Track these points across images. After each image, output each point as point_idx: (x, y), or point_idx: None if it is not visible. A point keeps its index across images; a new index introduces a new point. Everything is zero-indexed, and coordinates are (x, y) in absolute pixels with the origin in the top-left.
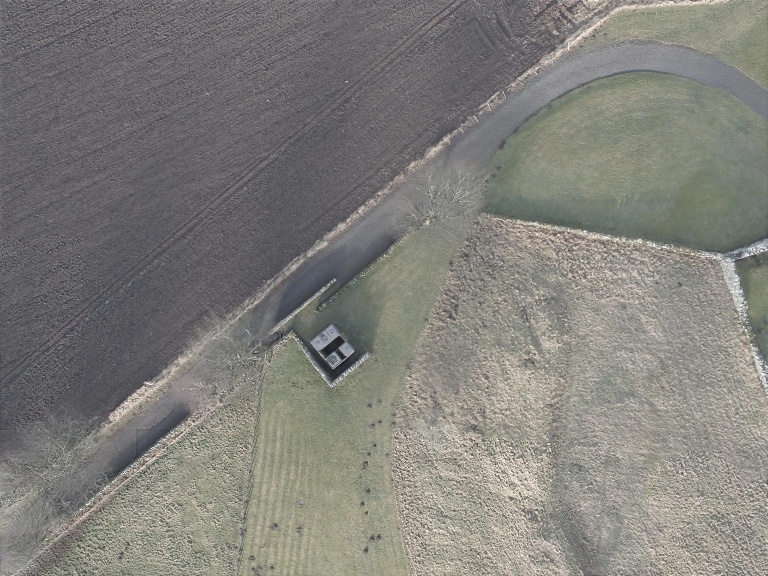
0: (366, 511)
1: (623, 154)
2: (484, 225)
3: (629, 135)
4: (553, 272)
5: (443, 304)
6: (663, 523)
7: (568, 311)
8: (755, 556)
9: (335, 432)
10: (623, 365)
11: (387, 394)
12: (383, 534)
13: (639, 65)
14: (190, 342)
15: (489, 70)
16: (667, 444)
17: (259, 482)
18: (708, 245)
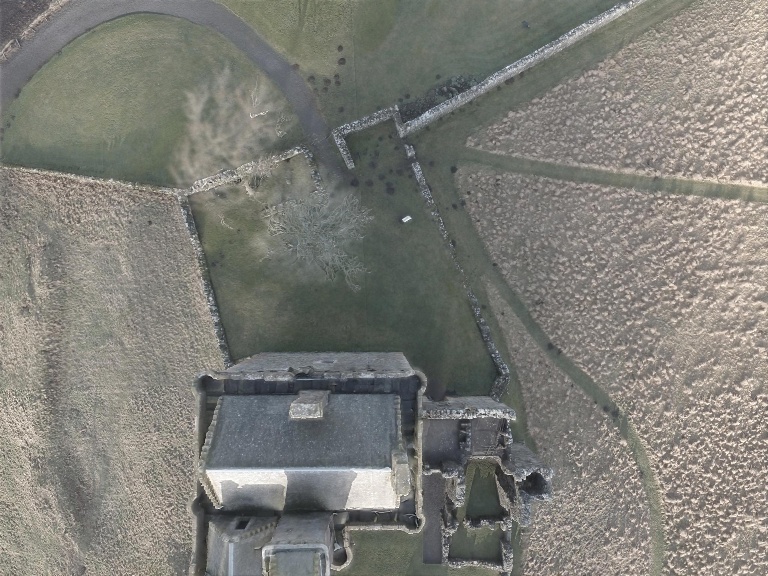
0: None
1: (115, 96)
2: (1, 176)
3: (121, 77)
4: (53, 218)
5: None
6: (133, 461)
7: (63, 256)
8: None
9: None
10: (105, 307)
11: None
12: None
13: (138, 7)
14: None
15: (4, 18)
16: (131, 382)
17: None
18: (177, 182)
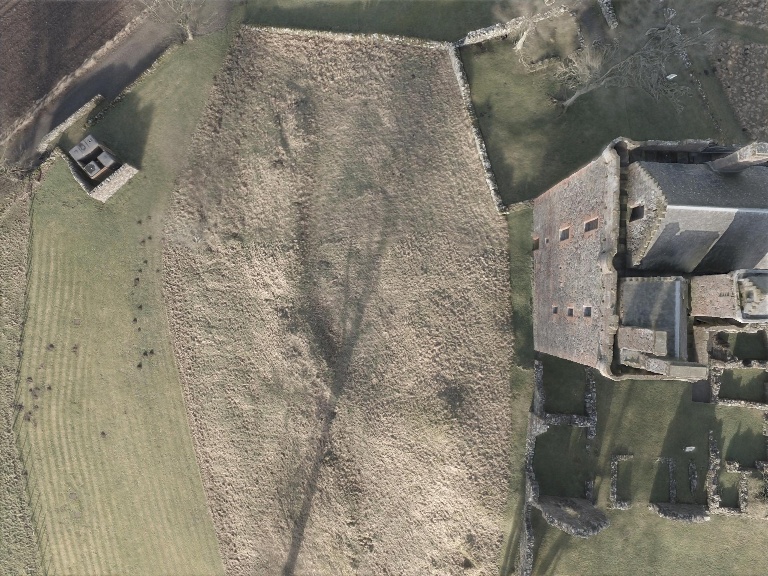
0: (139, 328)
1: None
2: (245, 38)
3: None
4: (304, 76)
5: (208, 119)
6: (394, 305)
7: (316, 112)
8: (470, 325)
9: (107, 250)
10: (363, 159)
11: (156, 210)
12: (156, 350)
13: None
14: None
15: None
16: (396, 228)
17: (35, 304)
18: (441, 38)
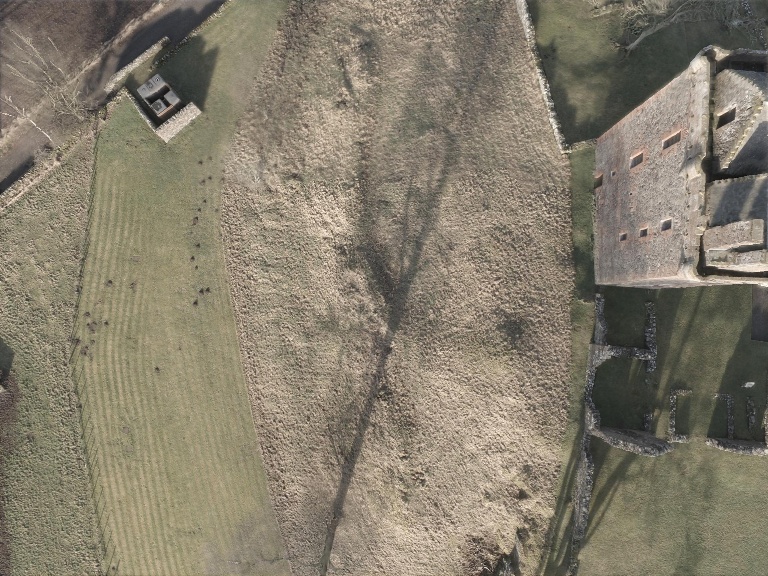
0: (196, 266)
1: None
2: None
3: None
4: (368, 21)
5: (271, 63)
6: (454, 242)
7: (379, 55)
8: (531, 260)
9: (167, 189)
10: (426, 100)
11: (217, 151)
12: (212, 287)
13: None
14: (29, 102)
15: None
16: (459, 165)
17: (95, 240)
18: None
